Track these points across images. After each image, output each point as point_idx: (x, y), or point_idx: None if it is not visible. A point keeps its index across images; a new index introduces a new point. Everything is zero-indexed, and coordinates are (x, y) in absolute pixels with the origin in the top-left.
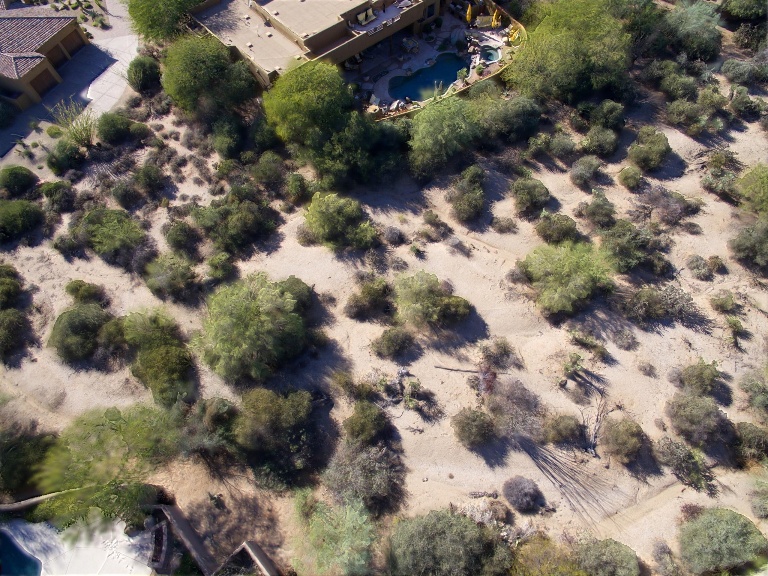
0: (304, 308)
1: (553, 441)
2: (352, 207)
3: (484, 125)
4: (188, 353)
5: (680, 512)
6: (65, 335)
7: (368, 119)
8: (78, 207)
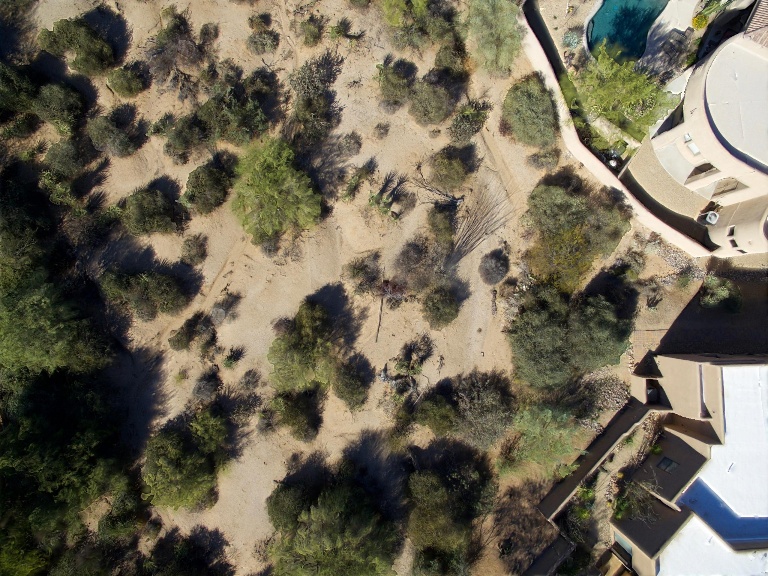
0: (305, 490)
1: None
2: (168, 448)
3: (26, 265)
4: None
5: (505, 138)
6: None
7: (8, 439)
8: None
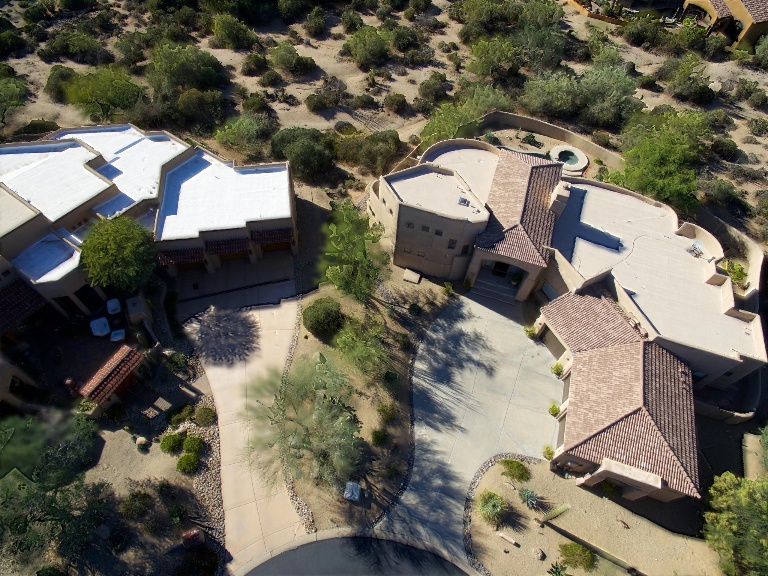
0: None
1: (361, 108)
2: None
3: None
4: (142, 90)
5: None
6: (57, 82)
7: None
8: (51, 38)
